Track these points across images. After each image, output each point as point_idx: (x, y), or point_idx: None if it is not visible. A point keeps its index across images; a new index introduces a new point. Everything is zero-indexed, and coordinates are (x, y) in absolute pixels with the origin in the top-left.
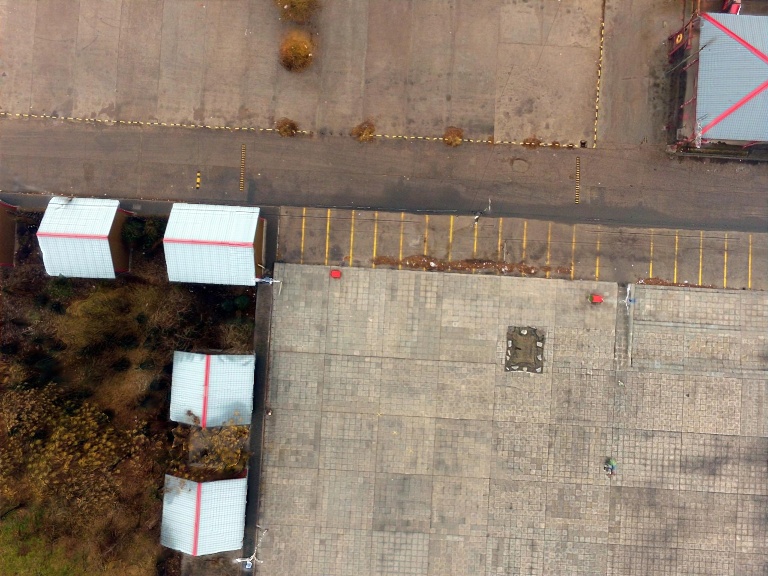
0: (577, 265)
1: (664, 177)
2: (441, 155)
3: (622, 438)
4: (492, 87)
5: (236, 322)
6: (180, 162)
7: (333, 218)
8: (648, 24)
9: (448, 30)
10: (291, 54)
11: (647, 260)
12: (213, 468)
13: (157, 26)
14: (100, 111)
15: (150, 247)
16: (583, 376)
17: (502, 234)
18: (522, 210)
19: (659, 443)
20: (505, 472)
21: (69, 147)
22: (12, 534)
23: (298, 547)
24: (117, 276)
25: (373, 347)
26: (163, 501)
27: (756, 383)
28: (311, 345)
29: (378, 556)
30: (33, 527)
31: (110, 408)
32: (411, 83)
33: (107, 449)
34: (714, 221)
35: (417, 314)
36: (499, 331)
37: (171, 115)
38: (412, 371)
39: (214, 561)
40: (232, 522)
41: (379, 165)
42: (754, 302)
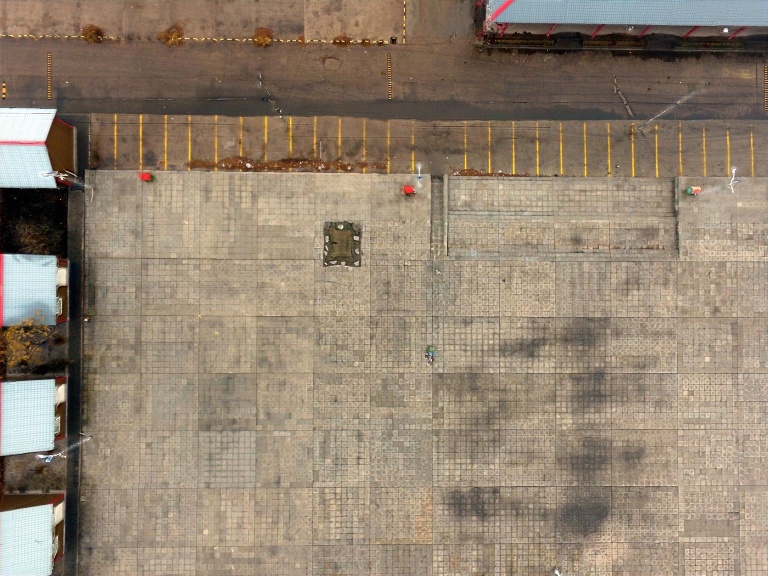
0: (393, 160)
1: (474, 70)
2: (252, 56)
3: (442, 326)
4: None
5: None
6: None
7: (145, 124)
8: None
9: None
10: None
11: (461, 152)
12: None
13: None
14: None
15: None
16: (401, 267)
17: (317, 132)
18: (336, 108)
19: (478, 329)
20: (328, 366)
21: None
22: None
23: (124, 452)
24: None
25: (190, 249)
26: None
27: (569, 265)
28: (127, 250)
29: (205, 456)
30: None
31: None
32: None
33: None
34: (525, 111)
35: (233, 214)
36: (316, 227)
37: None
38: (231, 271)
39: (37, 471)
40: (40, 423)
41: (190, 69)
42: (566, 188)
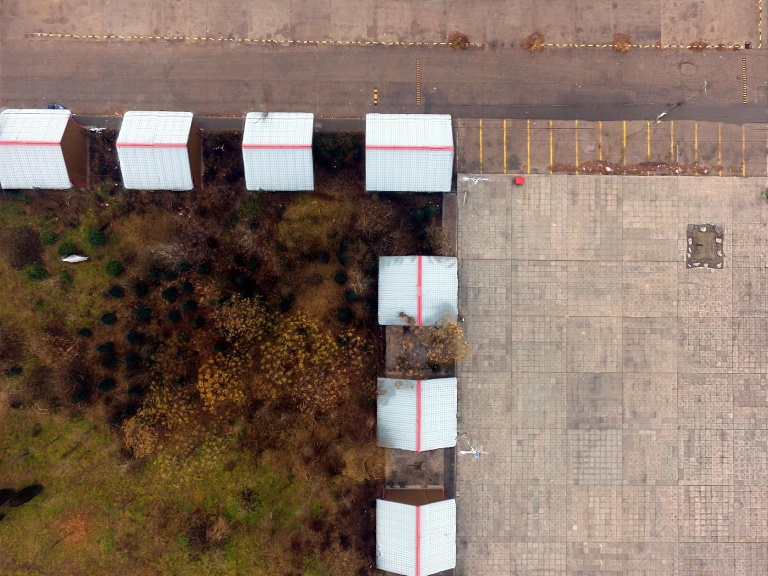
0: (748, 163)
1: None
2: (611, 62)
3: None
4: None
5: None
6: (357, 79)
7: (509, 128)
8: None
9: None
10: None
11: None
12: None
13: None
14: (275, 32)
15: (341, 160)
16: (762, 269)
17: (674, 136)
18: (692, 112)
19: None
20: (692, 366)
21: (247, 69)
22: None
23: (496, 449)
24: (314, 188)
25: (558, 251)
26: (377, 404)
27: None
28: (497, 252)
29: (574, 453)
30: (237, 443)
31: None
32: None
33: (332, 349)
34: None
35: (599, 217)
36: (679, 230)
37: (345, 33)
38: (597, 273)
39: (416, 466)
40: (446, 420)
41: (551, 74)
42: None
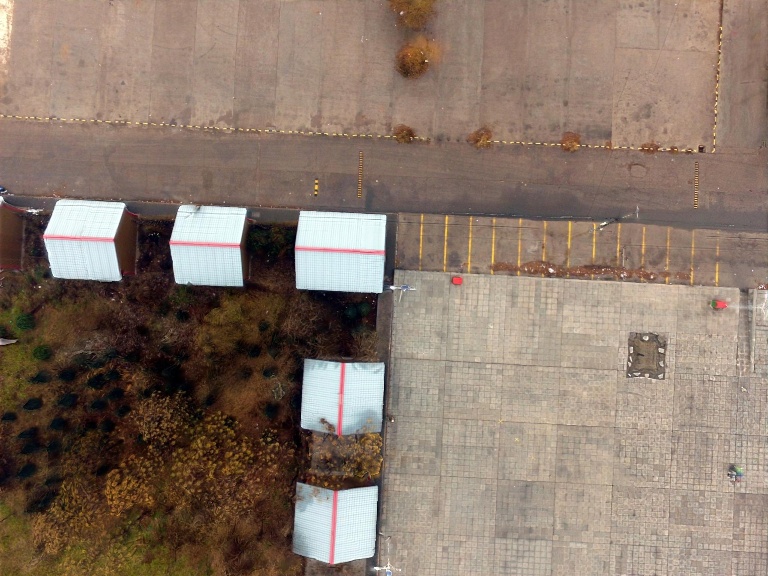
0: (696, 270)
1: None
2: (559, 161)
3: (745, 444)
4: (609, 92)
5: (363, 329)
6: (298, 169)
7: (451, 224)
8: (766, 28)
9: (564, 35)
10: (408, 60)
11: (767, 265)
12: (338, 475)
13: (274, 33)
14: (218, 119)
15: (274, 255)
16: (705, 382)
17: (621, 240)
18: (640, 215)
19: None
20: (628, 479)
21: (188, 155)
22: None
23: (421, 554)
24: None
25: (494, 354)
26: (295, 509)
27: None
28: (432, 352)
29: (501, 563)
30: (157, 534)
31: (231, 415)
32: (528, 89)
33: (247, 458)
34: None
35: (538, 320)
36: (620, 337)
37: (289, 122)
38: (533, 378)
39: (338, 568)
40: (365, 530)
41: (496, 171)
42: None
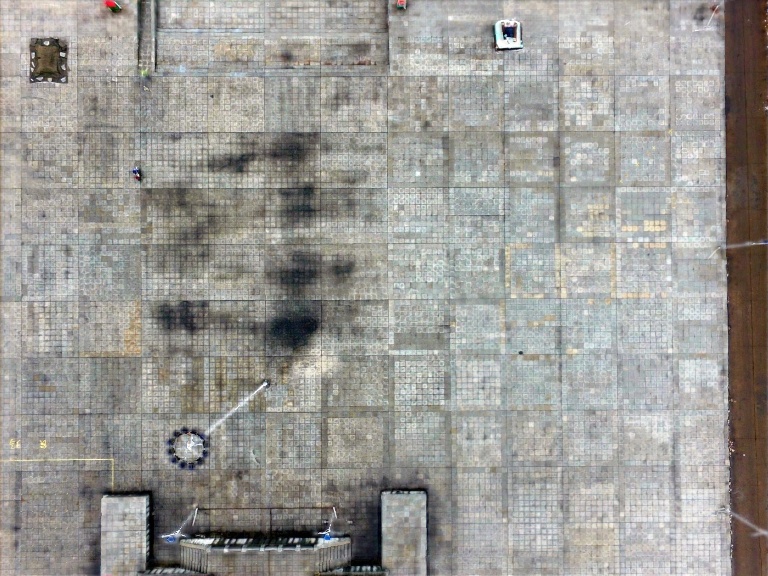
0: None
1: None
2: None
3: (150, 142)
4: None
5: None
6: None
7: None
8: None
9: None
10: None
11: None
12: None
13: None
14: None
15: None
16: (108, 83)
17: None
18: None
19: (186, 144)
20: (36, 181)
21: None
22: None
23: None
24: None
25: None
26: None
27: (278, 80)
28: None
29: None
30: None
31: None
32: None
33: None
34: None
35: None
36: (22, 44)
37: None
38: None
39: None
40: None
41: None
42: (277, 5)
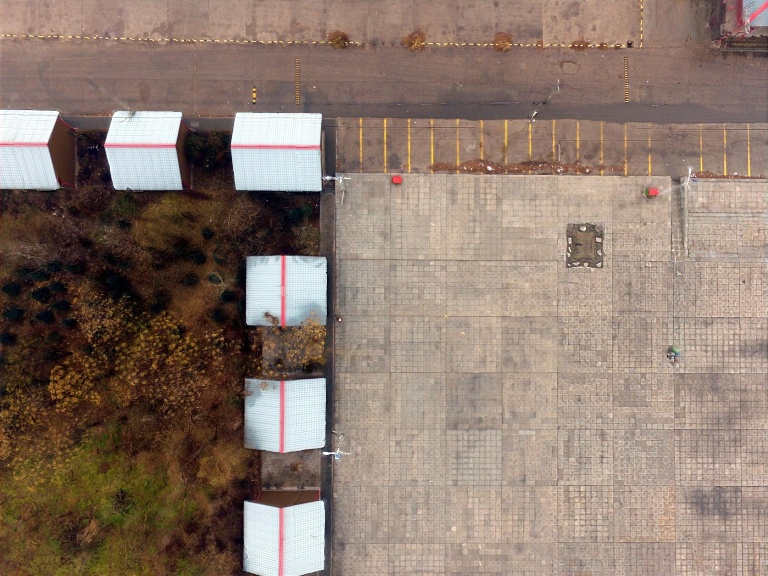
0: (630, 162)
1: (710, 73)
2: (492, 61)
3: (683, 326)
4: None
5: None
6: (235, 78)
7: (390, 127)
8: None
9: None
10: None
11: (697, 154)
12: None
13: None
14: (152, 31)
15: (213, 160)
16: (642, 268)
17: (556, 136)
18: (574, 111)
19: (718, 329)
20: (572, 366)
21: (123, 68)
22: (90, 453)
23: (374, 450)
24: (184, 188)
25: (437, 251)
26: (244, 405)
27: None
28: (376, 252)
29: (453, 454)
30: (111, 445)
31: None
32: None
33: (191, 350)
34: (760, 113)
35: (478, 216)
36: (559, 229)
37: (223, 32)
38: (476, 272)
39: (293, 467)
40: (314, 421)
41: (432, 73)
42: None
